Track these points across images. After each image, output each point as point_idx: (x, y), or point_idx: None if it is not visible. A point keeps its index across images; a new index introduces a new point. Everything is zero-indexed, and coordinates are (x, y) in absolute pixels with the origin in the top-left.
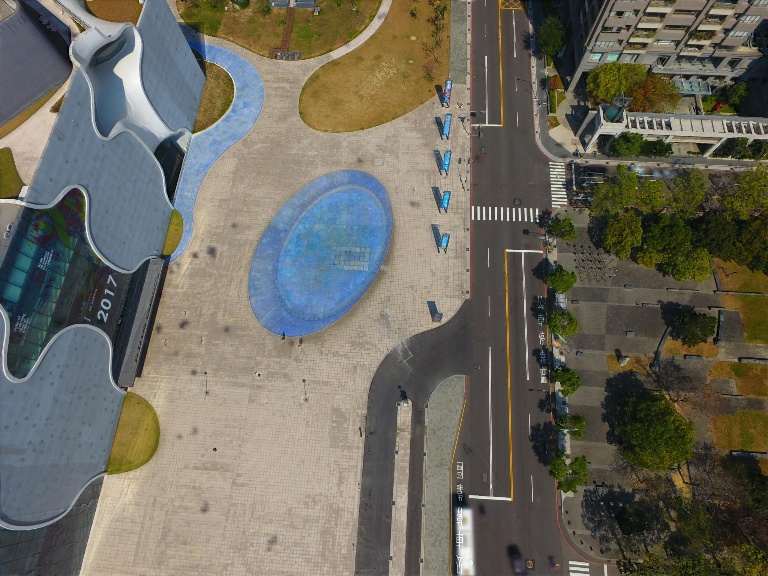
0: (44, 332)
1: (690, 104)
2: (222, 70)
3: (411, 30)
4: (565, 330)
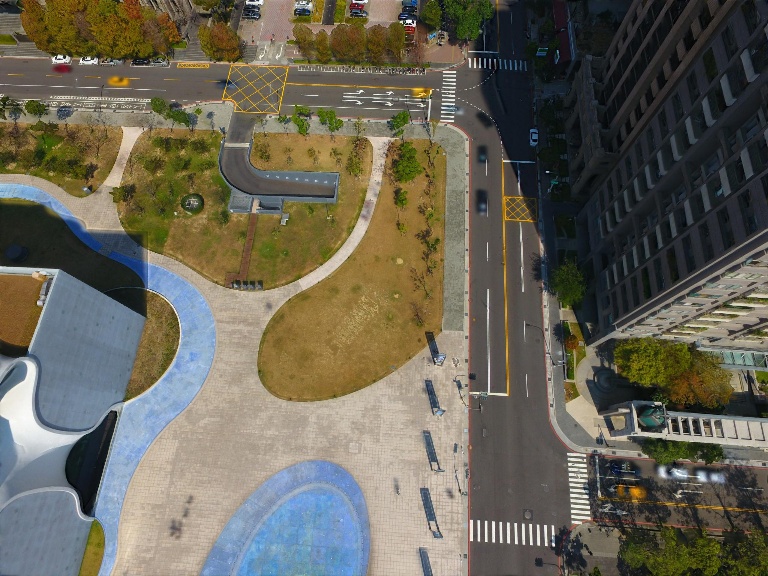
0: None
1: (740, 371)
2: (166, 304)
3: (397, 249)
4: None
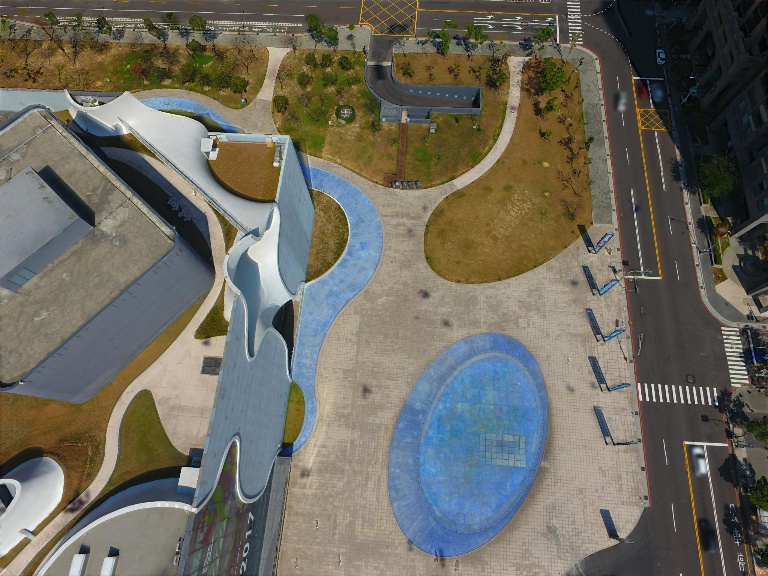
0: None
1: None
2: (332, 201)
3: (542, 154)
4: None
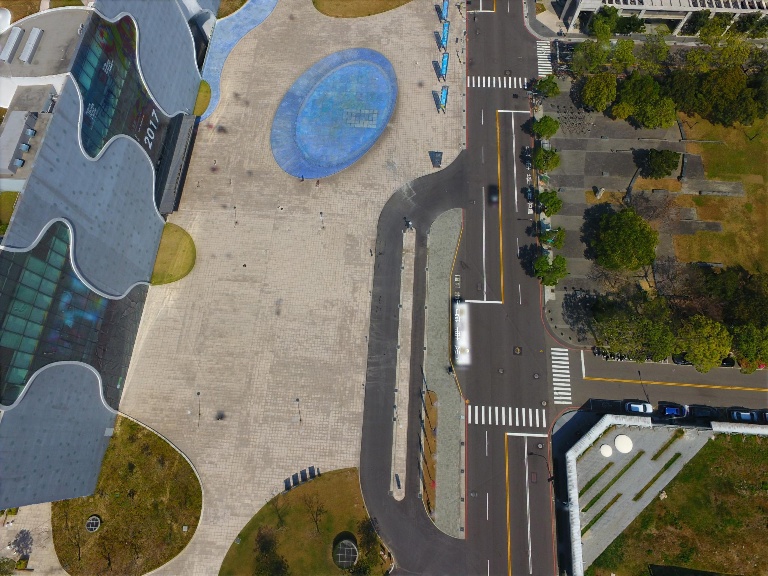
0: (106, 129)
1: None
2: None
3: None
4: (548, 162)
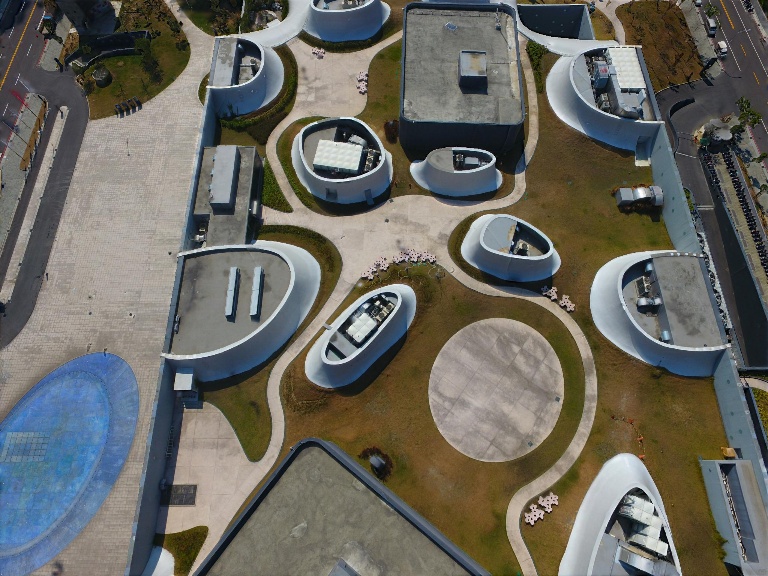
0: None
1: None
2: None
3: None
4: None
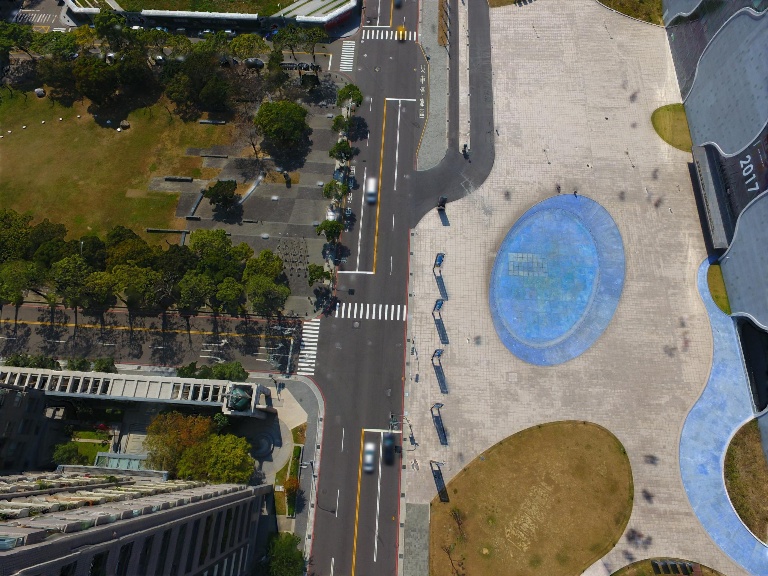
0: None
1: None
2: (763, 538)
3: None
4: None
